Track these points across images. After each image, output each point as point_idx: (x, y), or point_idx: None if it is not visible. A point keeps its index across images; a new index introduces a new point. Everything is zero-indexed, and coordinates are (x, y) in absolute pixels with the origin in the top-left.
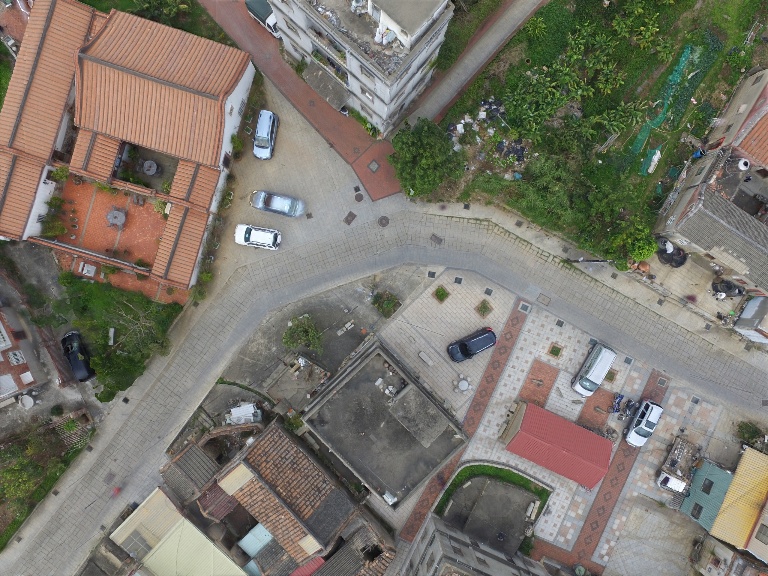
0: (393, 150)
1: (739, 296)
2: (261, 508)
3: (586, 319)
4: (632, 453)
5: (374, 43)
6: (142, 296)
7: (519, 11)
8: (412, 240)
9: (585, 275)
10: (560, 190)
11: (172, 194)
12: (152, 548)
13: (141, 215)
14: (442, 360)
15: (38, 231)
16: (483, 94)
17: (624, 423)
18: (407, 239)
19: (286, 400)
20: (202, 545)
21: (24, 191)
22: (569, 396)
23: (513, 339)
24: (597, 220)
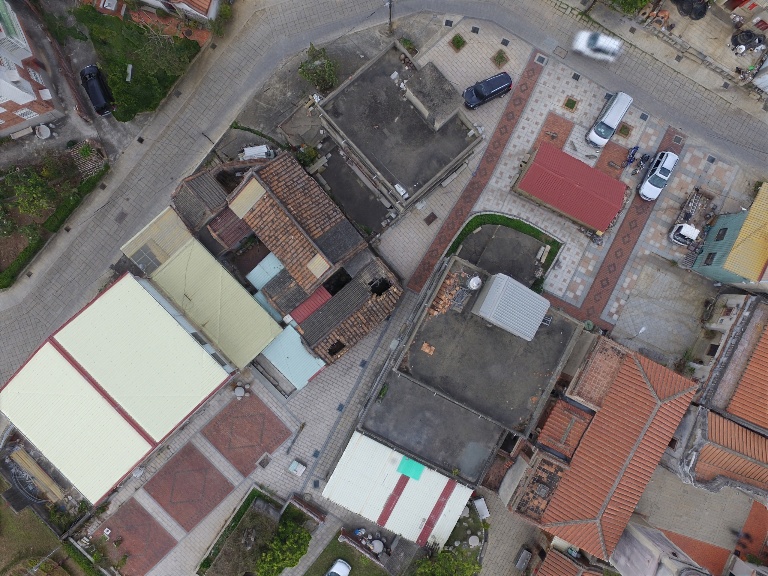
0: None
1: (759, 52)
2: (271, 230)
3: (602, 73)
4: (645, 211)
5: None
6: None
7: None
8: None
9: (603, 29)
10: None
11: None
12: (161, 264)
13: None
14: None
15: None
16: None
17: (638, 180)
18: None
19: (299, 136)
20: (211, 266)
21: None
22: (583, 151)
23: (528, 91)
24: None
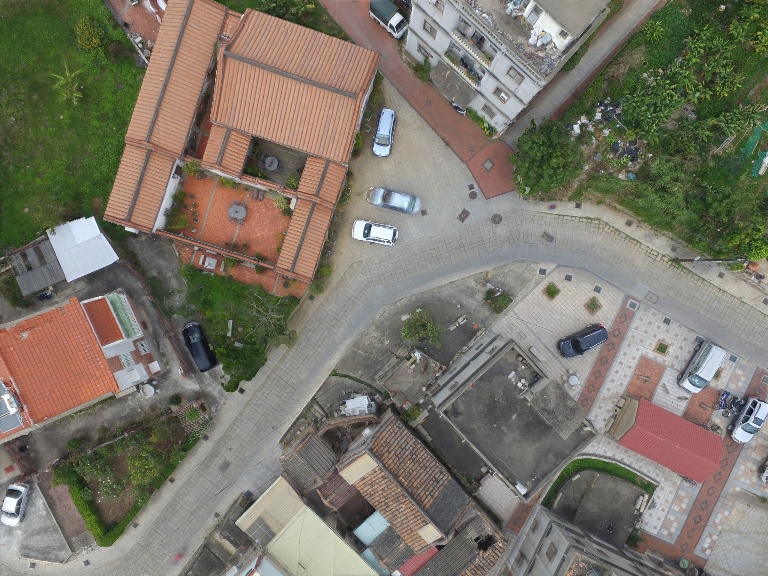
0: (507, 149)
1: None
2: (381, 497)
3: (693, 317)
4: (735, 449)
5: (528, 45)
6: (262, 289)
7: (633, 14)
8: (524, 238)
9: (693, 274)
10: (680, 190)
11: (301, 189)
12: (276, 535)
13: (259, 210)
14: (551, 355)
15: (163, 224)
16: (601, 95)
17: (728, 419)
18: (519, 236)
19: (402, 392)
20: (323, 532)
21: (156, 185)
22: (675, 392)
23: (621, 336)
24: (712, 220)
